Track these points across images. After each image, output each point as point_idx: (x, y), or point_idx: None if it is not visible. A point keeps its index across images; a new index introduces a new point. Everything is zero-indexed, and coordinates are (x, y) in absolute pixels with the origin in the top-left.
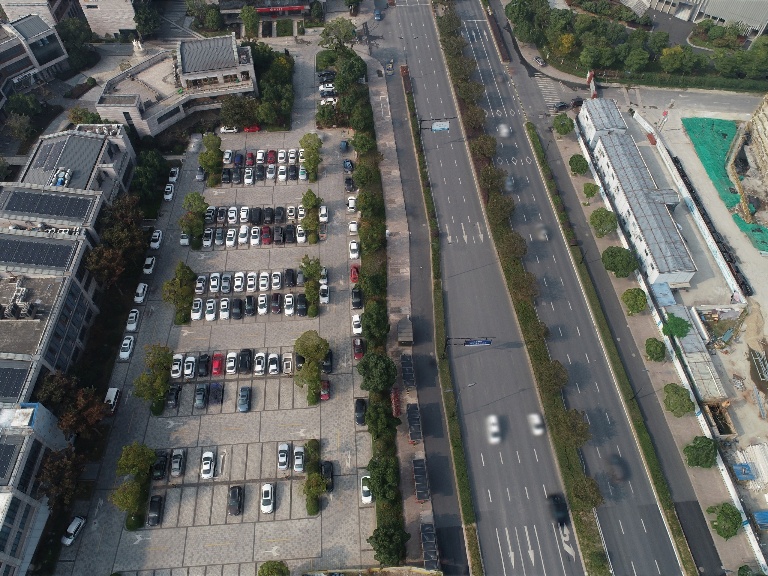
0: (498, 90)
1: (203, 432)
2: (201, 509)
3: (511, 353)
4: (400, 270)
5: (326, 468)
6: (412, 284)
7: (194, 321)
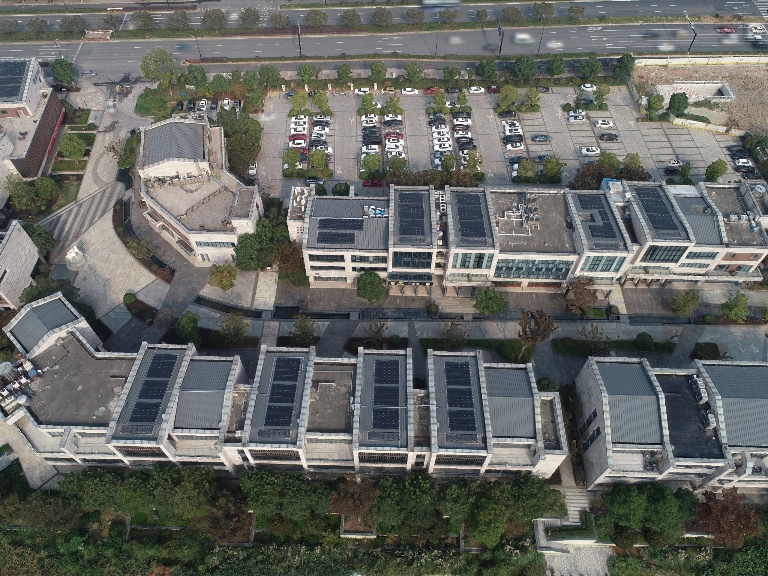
0: (234, 17)
1: (568, 158)
2: (617, 153)
3: (490, 34)
4: (427, 73)
5: (582, 100)
6: (438, 69)
7: (480, 171)
